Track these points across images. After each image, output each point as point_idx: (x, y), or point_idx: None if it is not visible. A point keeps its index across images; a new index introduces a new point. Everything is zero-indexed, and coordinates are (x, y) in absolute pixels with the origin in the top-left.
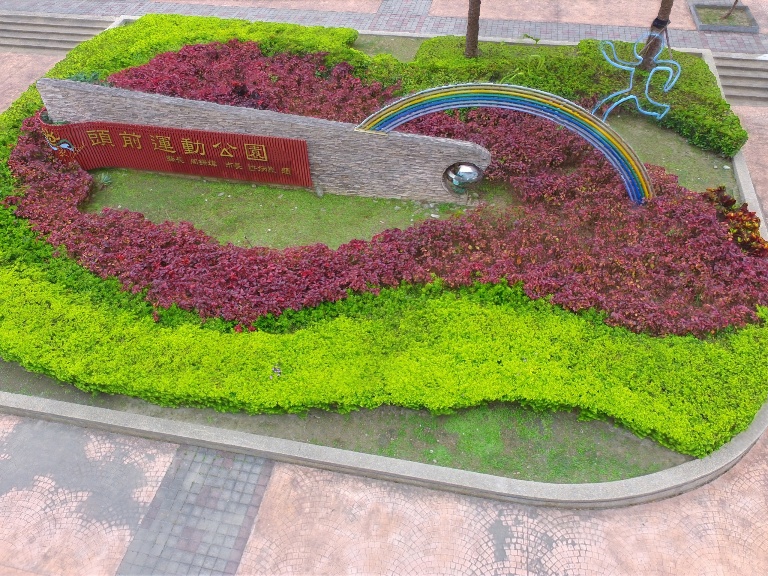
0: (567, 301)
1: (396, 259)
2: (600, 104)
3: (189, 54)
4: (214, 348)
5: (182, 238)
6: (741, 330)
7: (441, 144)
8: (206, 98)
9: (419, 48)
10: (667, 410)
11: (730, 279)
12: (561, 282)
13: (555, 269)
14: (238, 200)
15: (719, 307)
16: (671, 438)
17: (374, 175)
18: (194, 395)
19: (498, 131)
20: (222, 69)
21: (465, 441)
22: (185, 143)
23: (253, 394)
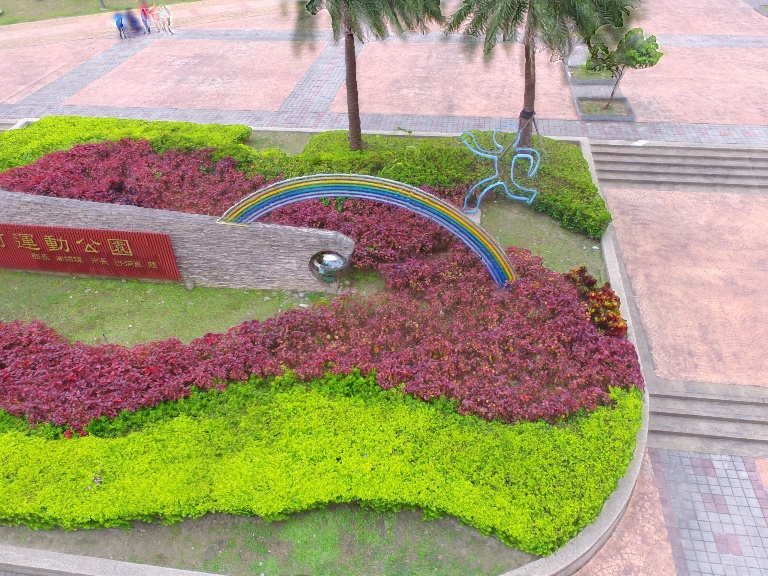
0: (417, 390)
1: (248, 352)
2: (471, 191)
3: (78, 153)
4: (34, 457)
5: (28, 338)
6: (592, 413)
7: (302, 234)
8: (83, 195)
9: (309, 142)
10: (508, 504)
11: (585, 360)
12: (414, 370)
13: (410, 356)
14: (104, 296)
15: (572, 390)
16: (511, 536)
17: (241, 266)
18: (1, 512)
19: (371, 219)
20: (108, 167)
21: (299, 550)
22: (48, 240)
23: (66, 508)
